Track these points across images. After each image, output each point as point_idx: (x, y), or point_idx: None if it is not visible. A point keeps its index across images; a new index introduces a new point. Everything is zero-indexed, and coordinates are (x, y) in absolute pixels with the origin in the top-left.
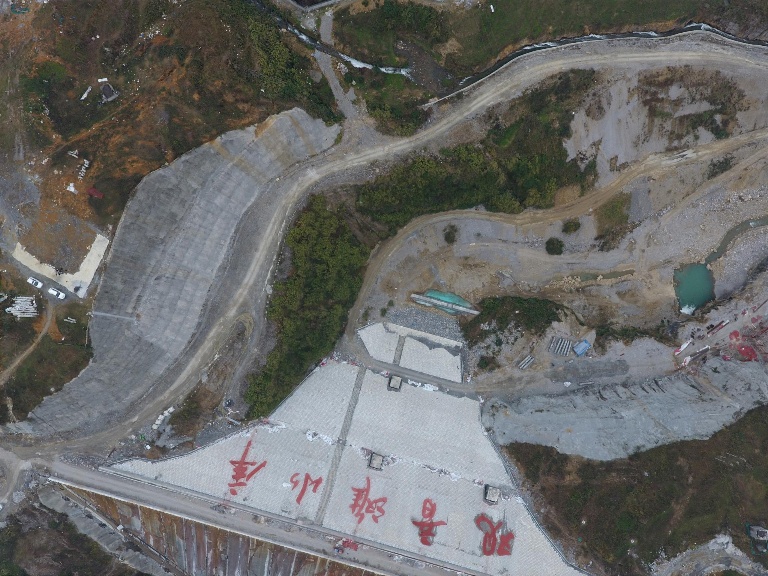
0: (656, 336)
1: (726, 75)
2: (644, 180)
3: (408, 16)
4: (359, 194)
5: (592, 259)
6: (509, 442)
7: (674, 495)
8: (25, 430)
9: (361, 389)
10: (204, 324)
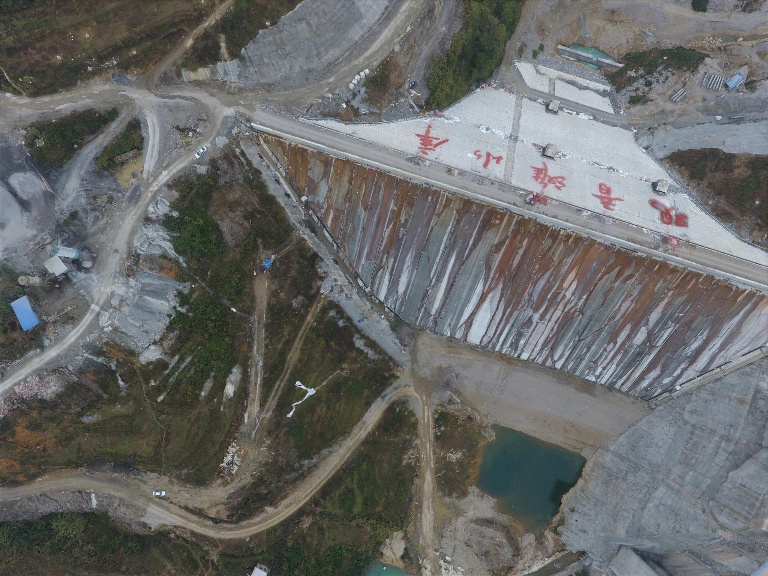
0: None
1: None
2: None
3: None
4: None
5: (735, 19)
6: (671, 152)
7: None
8: (231, 76)
9: (522, 108)
10: None
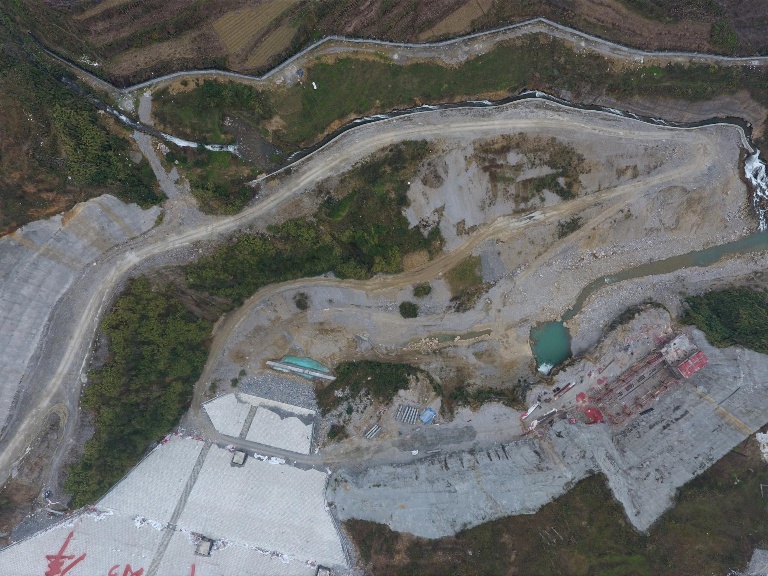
0: (508, 398)
1: (562, 141)
2: (493, 243)
3: (229, 95)
4: (187, 273)
5: (448, 321)
6: (347, 518)
7: (495, 575)
8: None
9: (202, 467)
10: (15, 416)
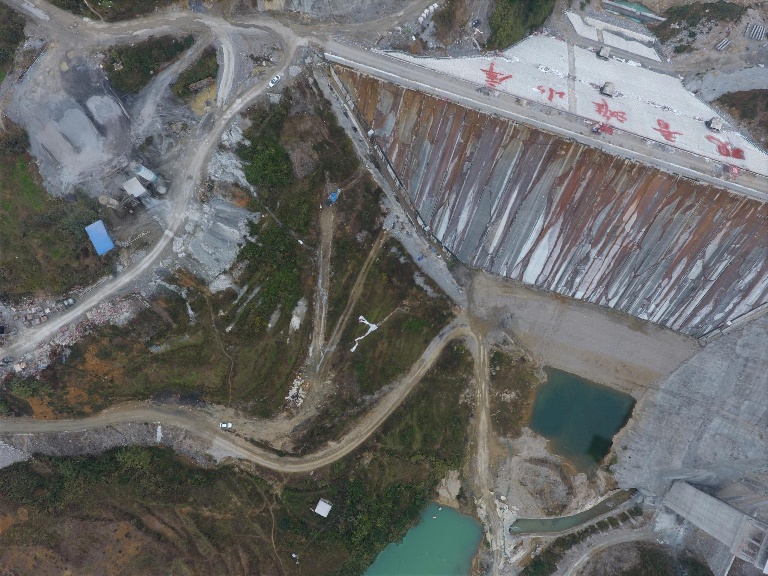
0: None
1: None
2: None
3: None
4: None
5: None
6: (721, 94)
7: None
8: (305, 7)
9: (575, 54)
10: None
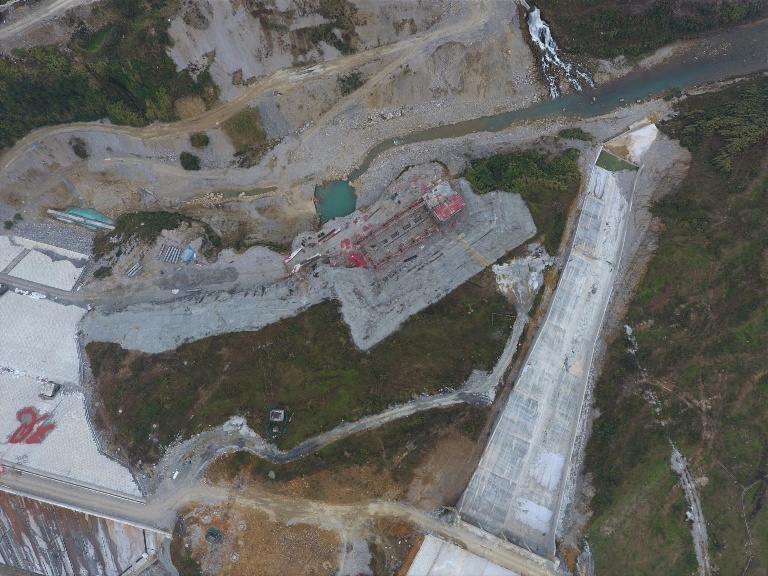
0: None
1: None
2: (271, 94)
3: None
4: None
5: (231, 175)
6: (88, 342)
7: (204, 381)
8: None
9: None
10: None
